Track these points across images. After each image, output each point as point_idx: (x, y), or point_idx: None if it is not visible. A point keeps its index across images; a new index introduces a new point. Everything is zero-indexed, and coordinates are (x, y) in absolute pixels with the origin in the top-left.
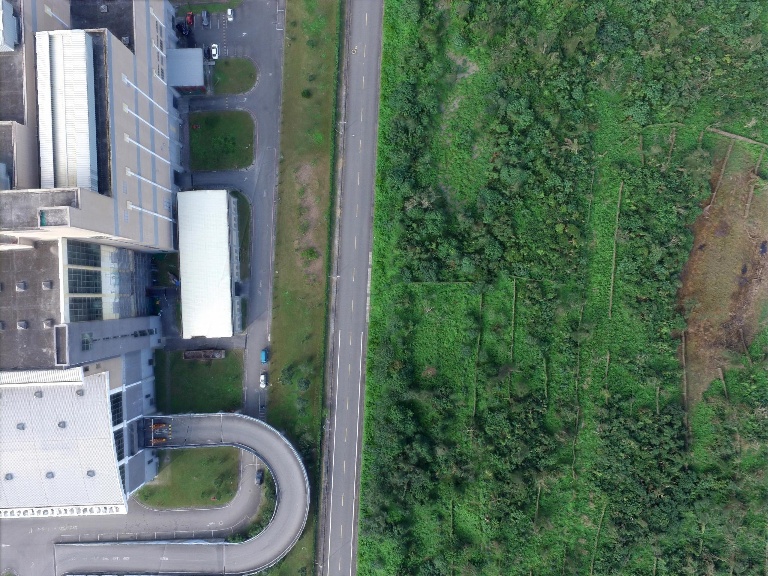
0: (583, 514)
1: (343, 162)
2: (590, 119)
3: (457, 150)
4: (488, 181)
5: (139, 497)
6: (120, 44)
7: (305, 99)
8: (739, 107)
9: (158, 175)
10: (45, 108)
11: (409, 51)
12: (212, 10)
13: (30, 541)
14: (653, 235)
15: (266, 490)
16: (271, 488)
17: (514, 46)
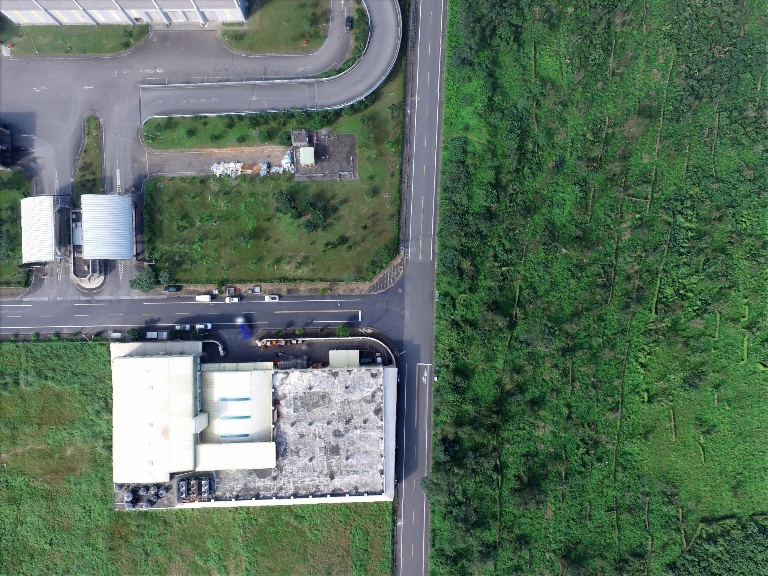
0: (653, 69)
1: None
2: None
3: None
4: None
5: (228, 41)
6: None
7: None
8: None
9: None
10: None
11: None
12: None
13: (114, 84)
14: None
15: None
16: (363, 22)
17: None
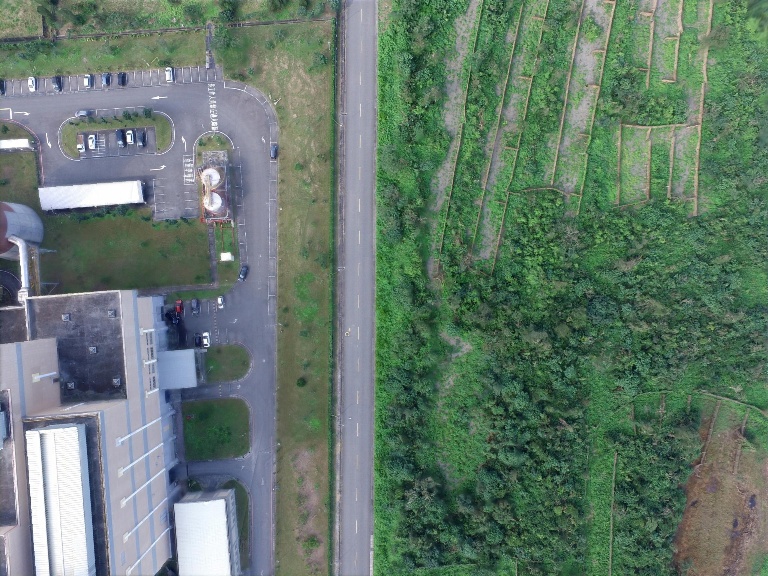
0: None
1: (341, 446)
2: (583, 392)
3: (454, 427)
4: (486, 459)
5: None
6: (113, 410)
7: (300, 387)
8: (724, 371)
9: (154, 497)
10: (38, 511)
11: (403, 338)
12: (202, 297)
13: None
14: (648, 505)
15: None
16: None
17: (507, 336)
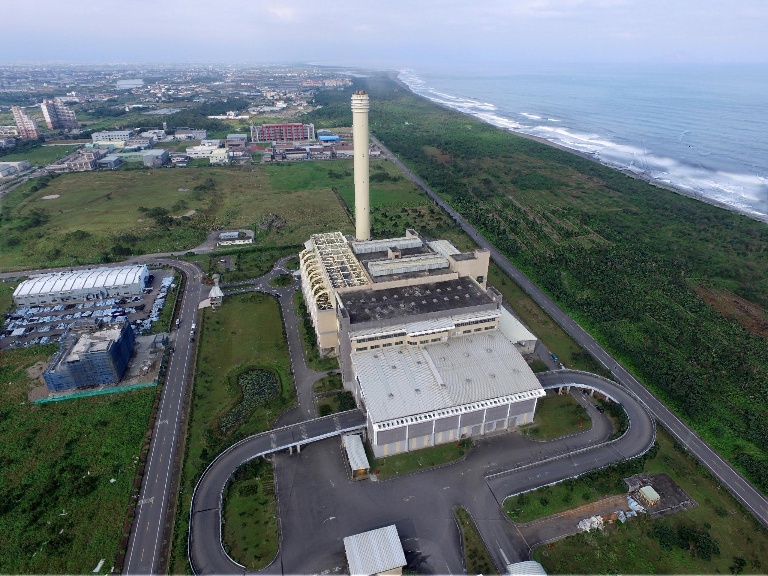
0: None
1: None
2: None
3: None
4: None
5: (530, 435)
6: None
7: (504, 286)
8: None
9: None
10: (443, 252)
11: None
12: None
13: (464, 481)
14: None
15: (609, 414)
16: None
17: None
